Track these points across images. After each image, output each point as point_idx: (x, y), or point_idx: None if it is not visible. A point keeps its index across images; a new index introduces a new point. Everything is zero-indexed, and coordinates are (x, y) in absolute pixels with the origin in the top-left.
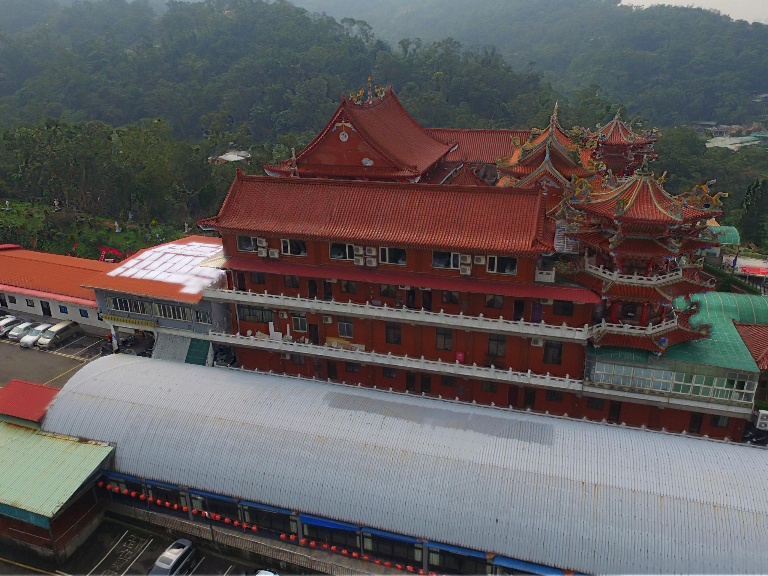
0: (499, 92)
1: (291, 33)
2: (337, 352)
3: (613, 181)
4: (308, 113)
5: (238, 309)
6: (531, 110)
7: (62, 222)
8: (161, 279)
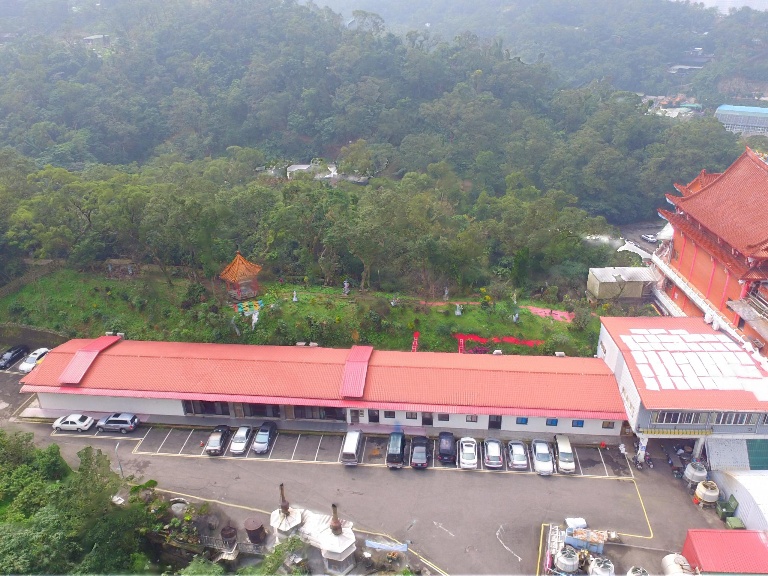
0: None
1: (304, 28)
2: None
3: None
4: (355, 119)
5: None
6: None
7: (385, 310)
8: (714, 387)
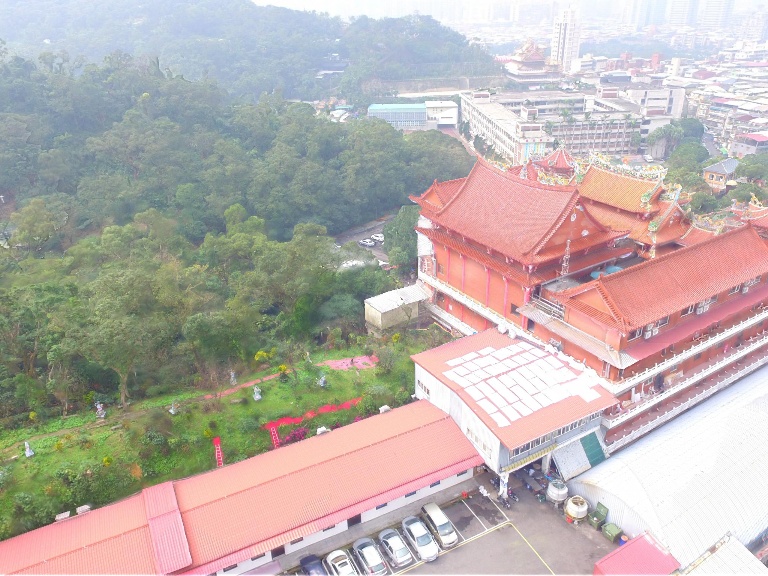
0: (211, 107)
1: None
2: None
3: (740, 206)
4: (2, 168)
5: None
6: None
7: (167, 424)
8: (550, 402)
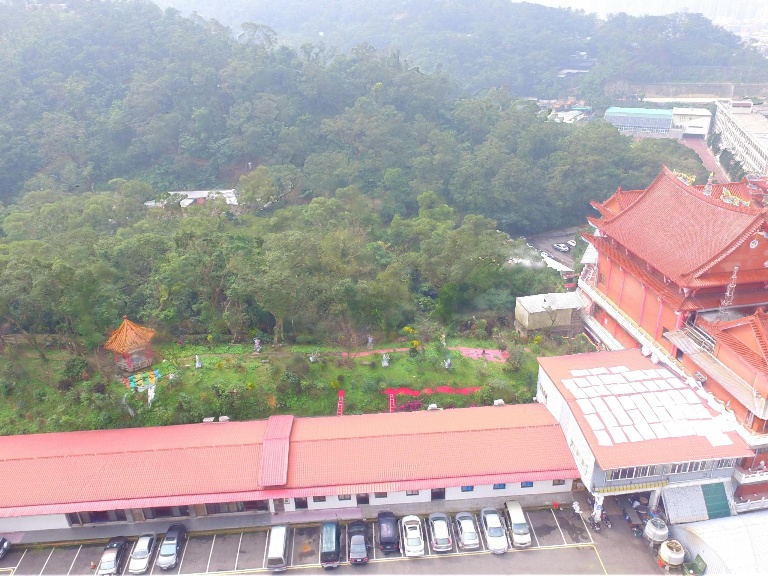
0: (436, 99)
1: (190, 43)
2: None
3: None
4: (253, 139)
5: None
6: None
7: (303, 368)
8: (667, 435)
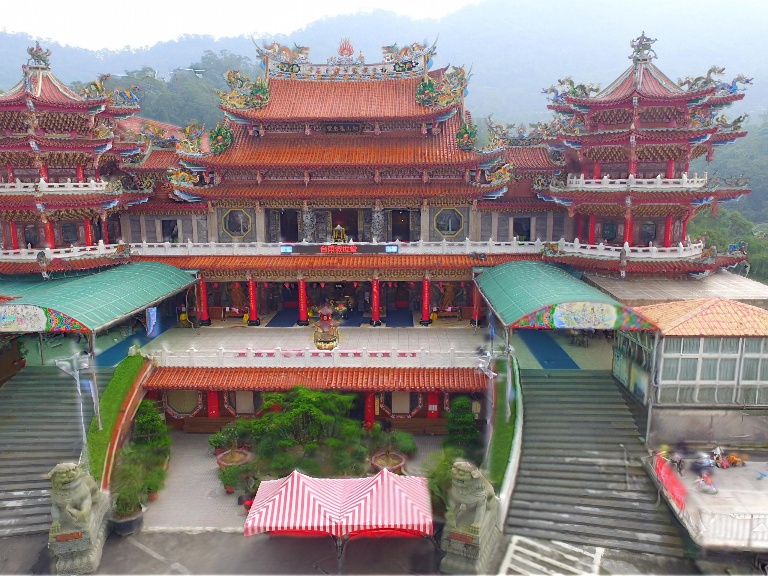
0: None
1: None
2: None
3: None
4: None
5: None
6: None
7: None
8: None
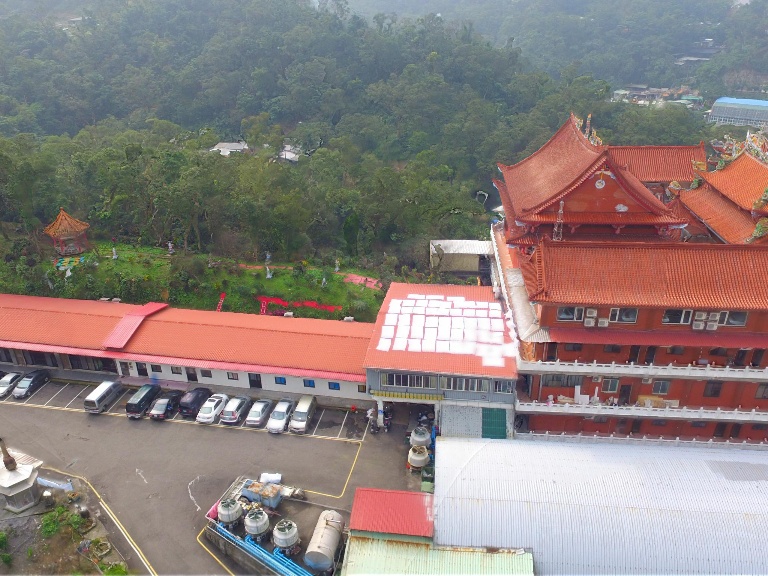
0: (493, 72)
1: (264, 9)
2: (662, 412)
3: None
4: (303, 99)
5: (543, 376)
6: (531, 91)
7: (196, 270)
8: (446, 350)
